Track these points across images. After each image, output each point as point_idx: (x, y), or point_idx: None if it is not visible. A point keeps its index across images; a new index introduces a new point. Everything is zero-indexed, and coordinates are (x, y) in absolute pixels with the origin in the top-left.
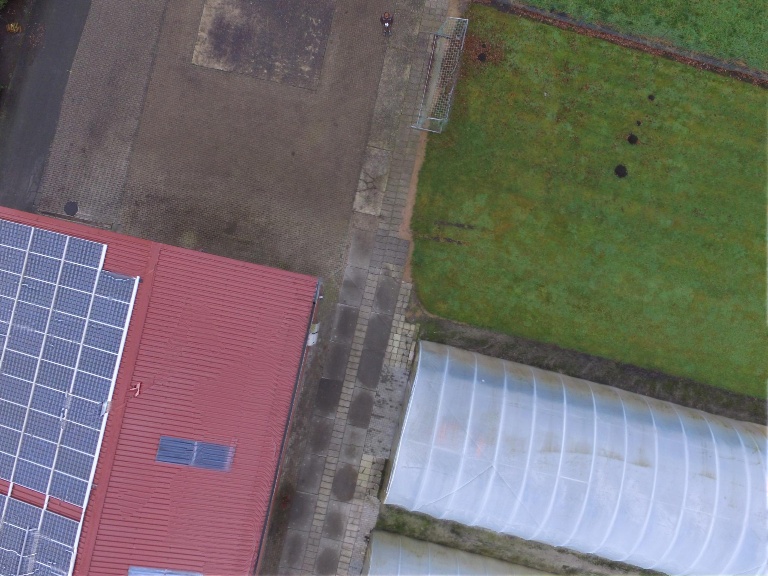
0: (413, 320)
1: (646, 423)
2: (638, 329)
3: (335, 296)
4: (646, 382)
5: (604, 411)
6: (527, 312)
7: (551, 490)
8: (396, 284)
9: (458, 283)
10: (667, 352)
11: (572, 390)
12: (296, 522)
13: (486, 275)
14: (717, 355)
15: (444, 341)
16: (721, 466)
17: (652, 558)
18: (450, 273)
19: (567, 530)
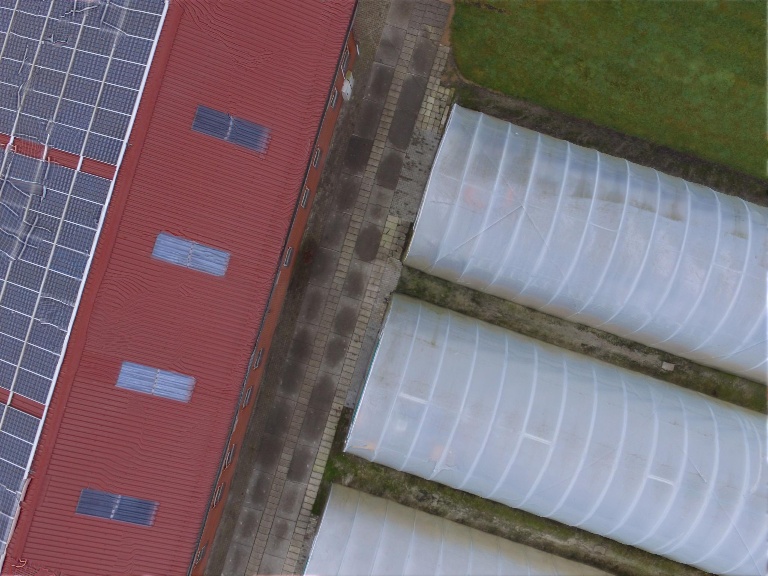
0: (448, 84)
1: (679, 187)
2: (675, 111)
3: (371, 54)
4: (679, 166)
5: (637, 173)
6: (564, 86)
7: (580, 235)
8: (434, 46)
9: (496, 51)
10: (703, 136)
11: (605, 155)
12: (317, 278)
13: (525, 45)
14: (754, 143)
15: (478, 108)
16: (754, 229)
17: (676, 321)
18: (489, 40)
19: (592, 284)
